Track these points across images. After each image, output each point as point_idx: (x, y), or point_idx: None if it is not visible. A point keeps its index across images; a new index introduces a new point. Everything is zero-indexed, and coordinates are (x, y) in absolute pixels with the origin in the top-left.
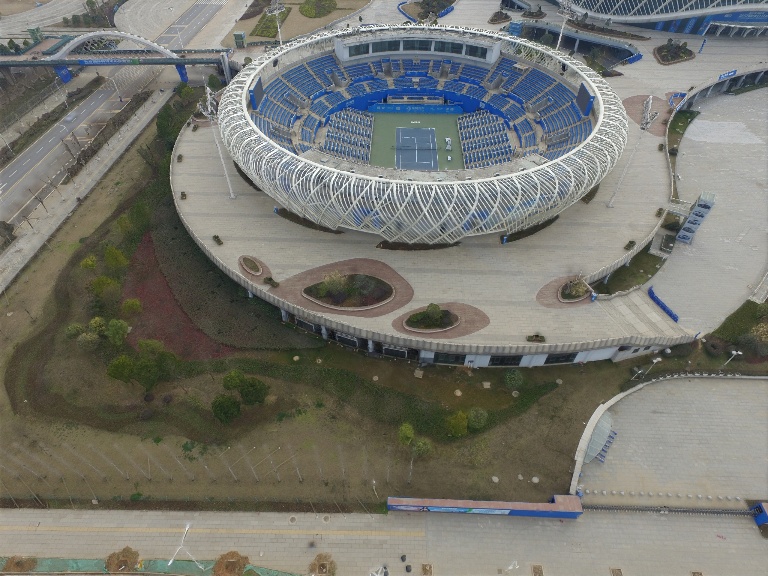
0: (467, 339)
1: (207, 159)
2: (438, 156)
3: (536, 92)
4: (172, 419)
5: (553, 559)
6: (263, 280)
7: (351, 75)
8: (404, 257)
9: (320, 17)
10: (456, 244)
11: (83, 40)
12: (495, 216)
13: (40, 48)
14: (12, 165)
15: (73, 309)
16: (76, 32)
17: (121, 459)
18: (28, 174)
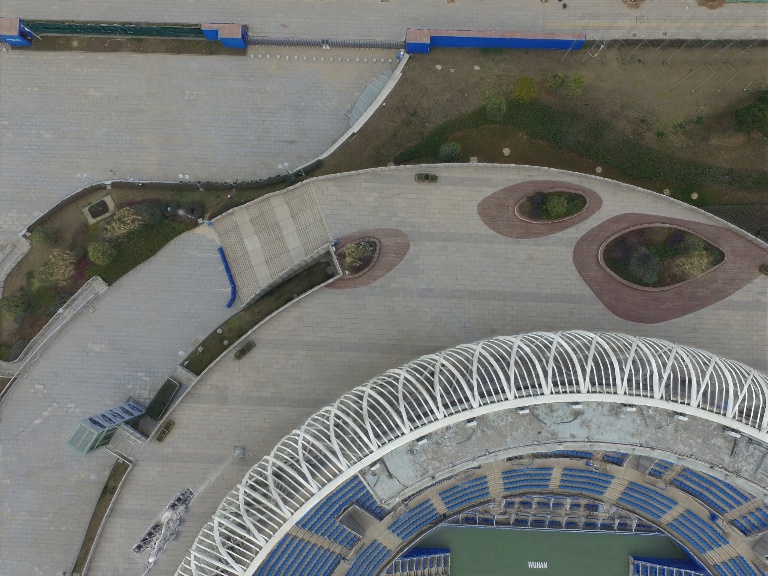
0: (510, 180)
1: None
2: None
3: None
4: None
5: (436, 8)
6: None
7: None
8: (585, 326)
9: None
10: None
11: None
12: None
13: None
14: None
15: None
16: None
17: None
18: None
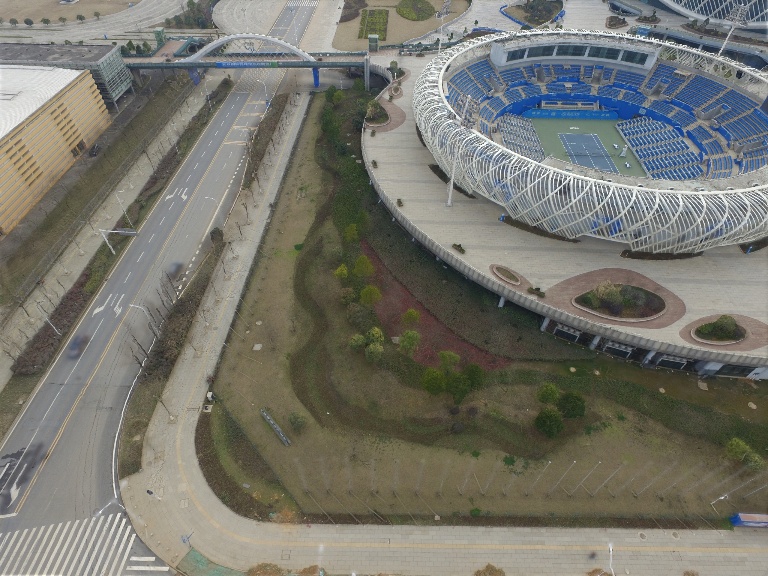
0: (764, 351)
1: (402, 165)
2: (615, 163)
3: (705, 99)
4: (482, 432)
5: None
6: (526, 290)
7: (506, 80)
8: (655, 267)
9: (423, 20)
10: (700, 254)
11: (222, 42)
12: (762, 226)
13: (167, 50)
14: (183, 169)
15: (330, 318)
16: (181, 33)
17: (447, 474)
18: (204, 179)
